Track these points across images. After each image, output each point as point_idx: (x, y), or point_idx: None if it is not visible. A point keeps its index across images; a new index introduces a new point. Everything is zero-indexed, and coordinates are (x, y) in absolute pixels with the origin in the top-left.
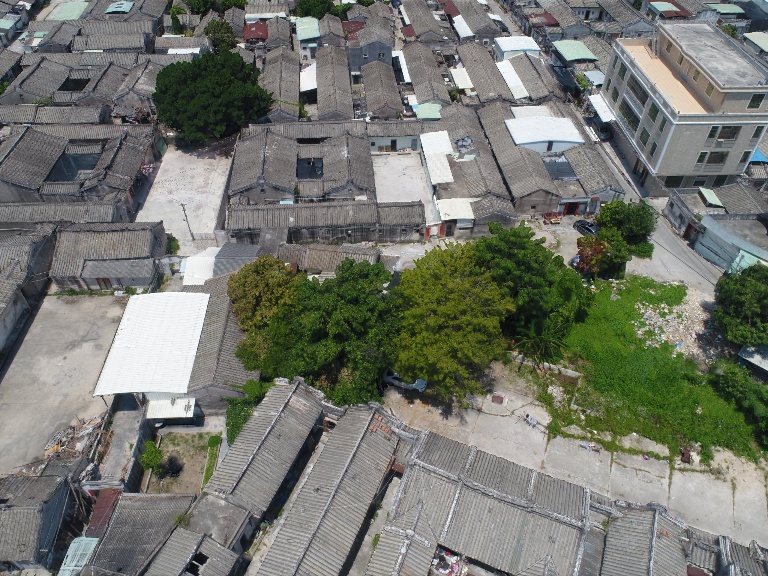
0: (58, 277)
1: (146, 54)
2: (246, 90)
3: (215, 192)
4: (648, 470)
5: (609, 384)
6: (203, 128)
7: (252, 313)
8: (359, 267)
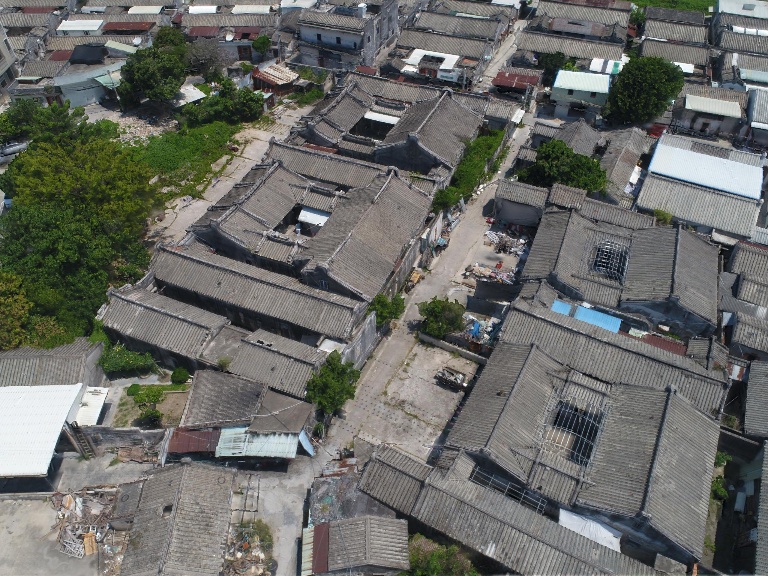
0: None
1: None
2: None
3: None
4: (238, 165)
5: (173, 162)
6: None
7: (8, 322)
8: (22, 207)
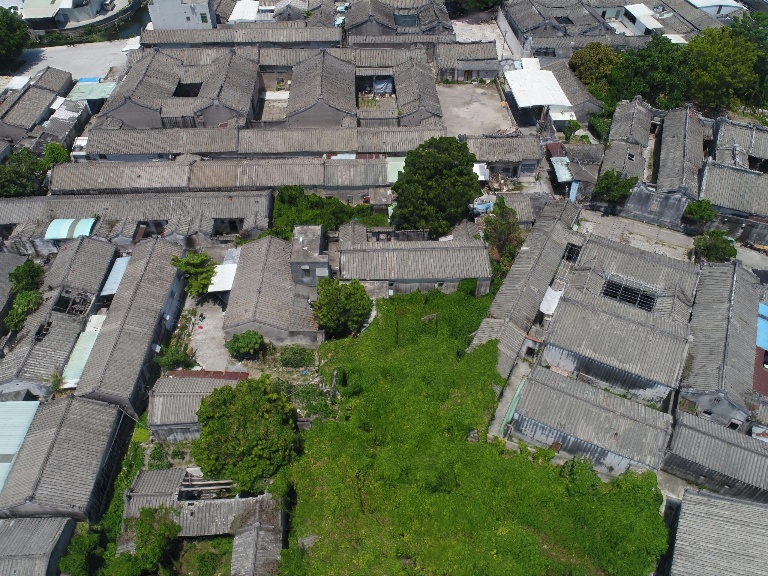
0: (444, 69)
1: None
2: None
3: None
4: None
5: None
6: (479, 0)
7: (595, 70)
8: None
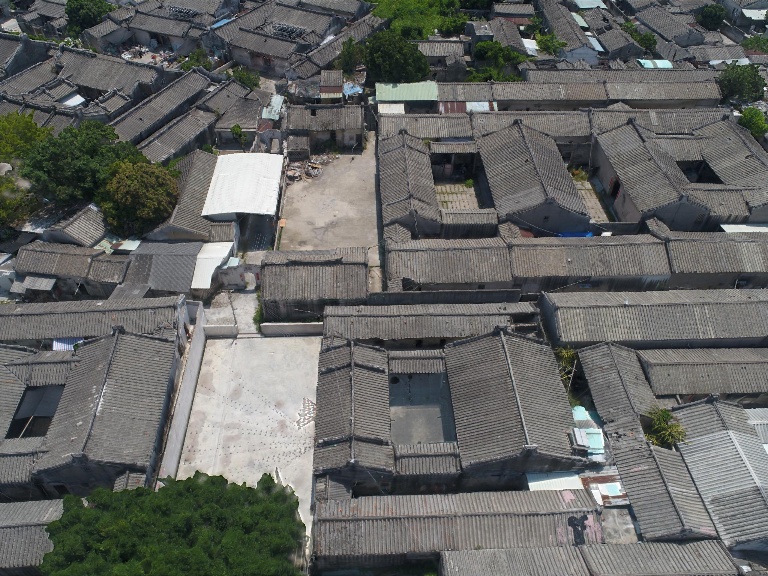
0: None
1: None
2: (82, 505)
3: (212, 427)
4: None
5: None
6: None
7: None
8: (47, 140)
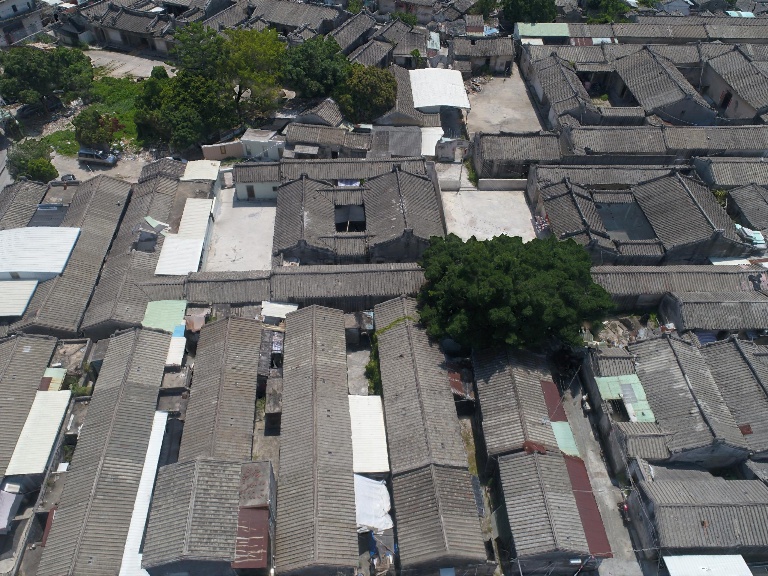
0: None
1: (765, 501)
2: None
3: (463, 240)
4: None
5: None
6: None
7: None
8: (304, 45)
